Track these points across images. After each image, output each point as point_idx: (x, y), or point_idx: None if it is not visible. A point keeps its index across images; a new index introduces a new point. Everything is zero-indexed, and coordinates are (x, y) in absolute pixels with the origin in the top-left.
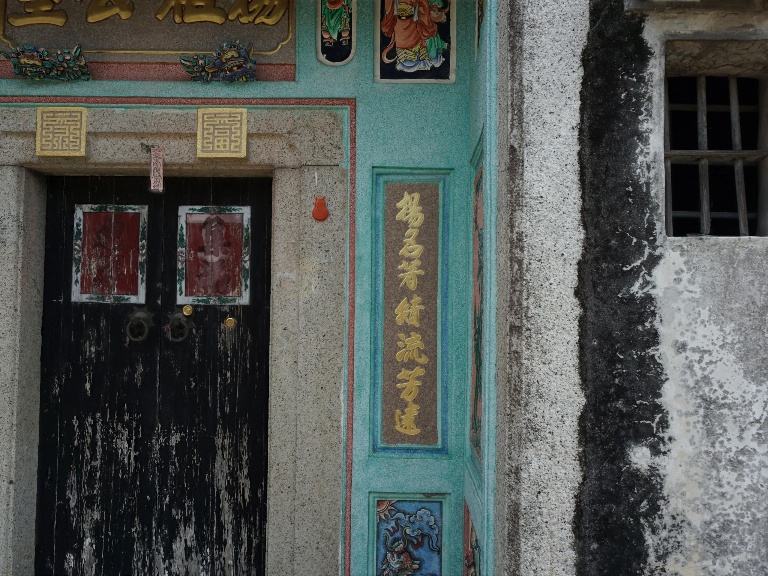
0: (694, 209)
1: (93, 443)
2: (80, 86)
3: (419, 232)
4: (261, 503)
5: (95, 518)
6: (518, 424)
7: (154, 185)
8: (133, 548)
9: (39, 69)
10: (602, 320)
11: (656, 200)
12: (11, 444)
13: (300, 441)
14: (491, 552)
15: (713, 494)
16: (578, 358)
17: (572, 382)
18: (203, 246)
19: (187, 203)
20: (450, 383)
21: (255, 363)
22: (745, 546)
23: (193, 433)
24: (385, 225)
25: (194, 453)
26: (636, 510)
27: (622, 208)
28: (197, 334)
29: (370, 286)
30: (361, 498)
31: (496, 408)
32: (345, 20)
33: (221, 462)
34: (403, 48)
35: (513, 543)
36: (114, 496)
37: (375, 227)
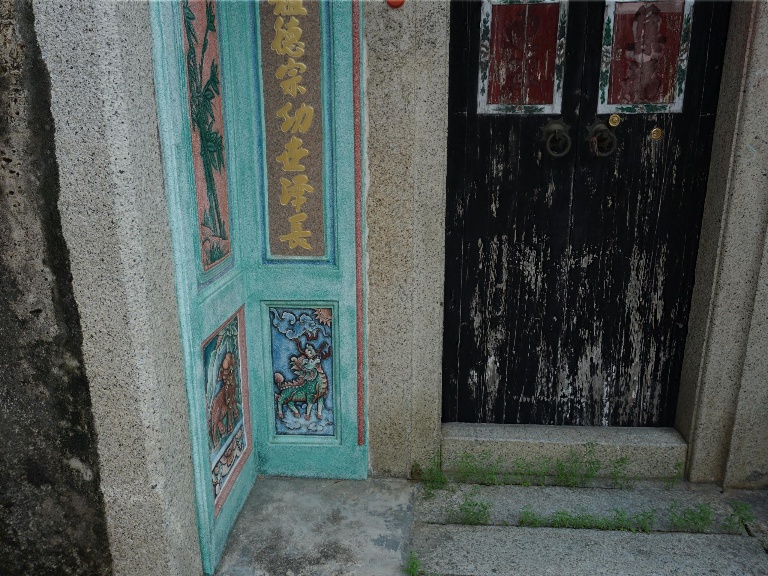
0: None
1: (499, 266)
2: None
3: None
4: (673, 323)
5: (499, 338)
6: None
7: None
8: (537, 365)
9: None
10: None
11: None
12: (441, 266)
13: (766, 260)
14: None
15: None
16: None
17: None
18: (633, 43)
19: None
20: None
21: (682, 179)
22: None
23: (607, 254)
24: None
25: (606, 274)
26: None
27: None
28: (618, 148)
29: None
30: None
31: None
32: None
33: (635, 283)
34: None
35: None
36: (520, 317)
37: None
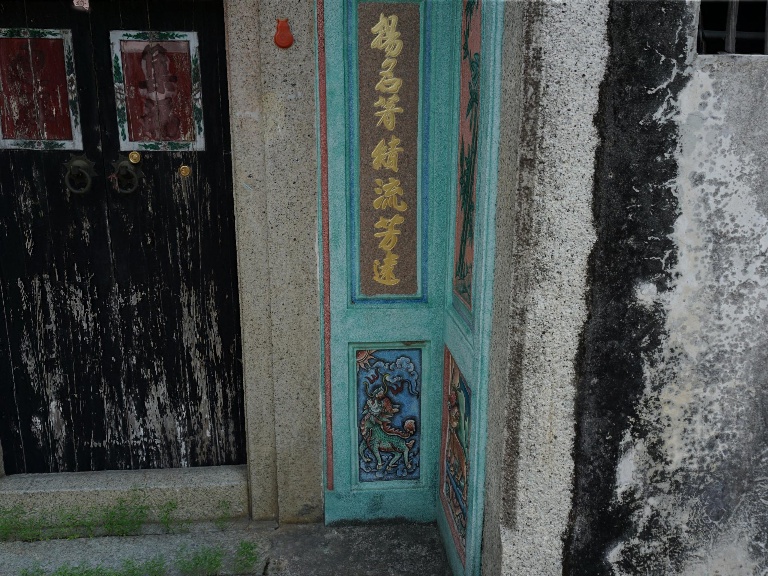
0: (716, 27)
1: (44, 306)
2: None
3: (397, 63)
4: (234, 359)
5: (58, 382)
6: (525, 265)
7: (77, 1)
8: (103, 408)
9: None
10: (620, 151)
11: (691, 10)
12: None
13: (274, 295)
14: (485, 392)
15: (712, 327)
16: (592, 193)
17: (584, 219)
18: (145, 81)
19: (119, 27)
20: (431, 231)
21: (217, 215)
22: (735, 374)
23: (155, 292)
24: (359, 54)
25: (158, 312)
26: (637, 345)
27: (653, 19)
28: (148, 184)
29: (344, 126)
30: (340, 349)
31: (495, 251)
32: None
33: (188, 320)
34: None
35: (515, 382)
36: (76, 359)
37: (347, 56)
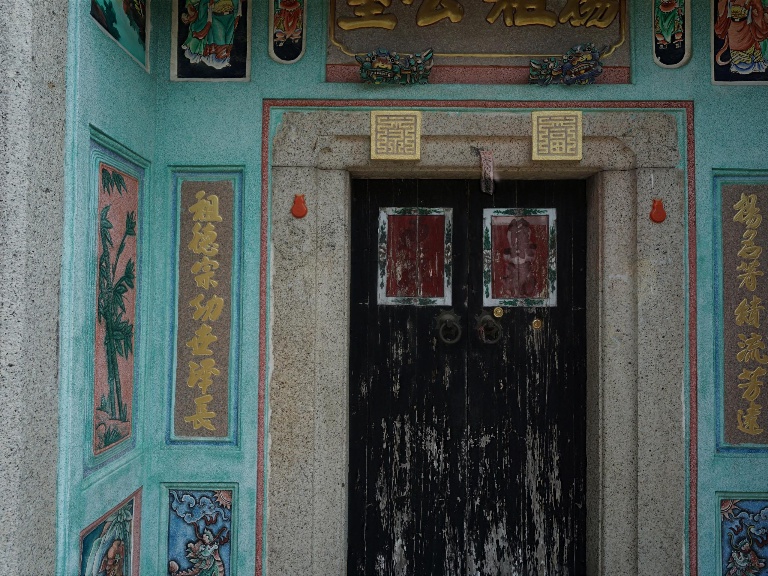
0: None
1: (402, 445)
2: (416, 90)
3: (757, 233)
4: (573, 503)
5: (405, 520)
6: None
7: (485, 188)
8: (444, 549)
9: (385, 73)
10: None
11: None
12: (342, 447)
13: (642, 442)
14: None
15: None
16: None
17: None
18: (509, 248)
19: (492, 205)
20: None
21: (564, 364)
22: None
23: (503, 434)
24: (722, 226)
25: (504, 454)
26: None
27: None
28: (504, 336)
29: (712, 287)
30: (708, 498)
31: None
32: (678, 23)
33: (532, 463)
34: (737, 50)
35: None
36: (424, 498)
37: (713, 229)
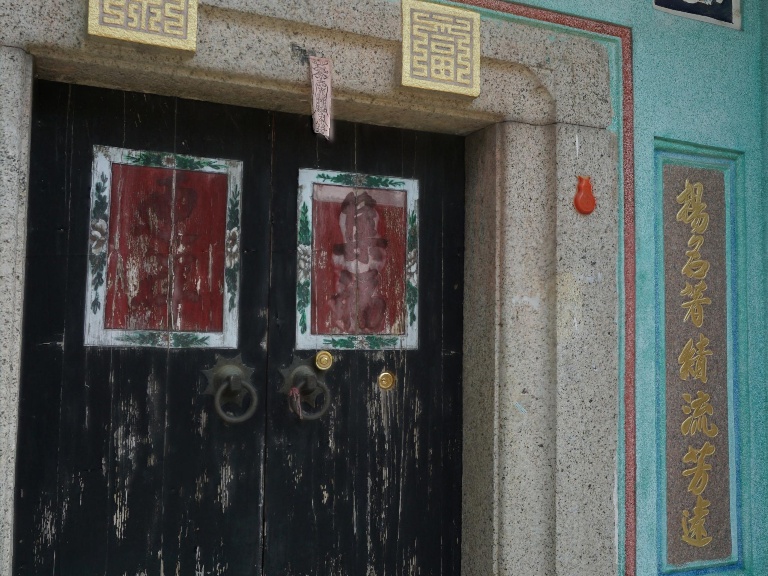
0: None
1: None
2: None
3: (704, 241)
4: None
5: None
6: None
7: (318, 126)
8: None
9: None
10: None
11: None
12: None
13: None
14: None
15: None
16: None
17: None
18: (342, 244)
19: (314, 164)
20: (746, 464)
21: (428, 450)
22: None
23: None
24: (664, 227)
25: None
26: None
27: None
28: (331, 403)
29: (654, 321)
30: None
31: None
32: None
33: None
34: None
35: None
36: None
37: None
